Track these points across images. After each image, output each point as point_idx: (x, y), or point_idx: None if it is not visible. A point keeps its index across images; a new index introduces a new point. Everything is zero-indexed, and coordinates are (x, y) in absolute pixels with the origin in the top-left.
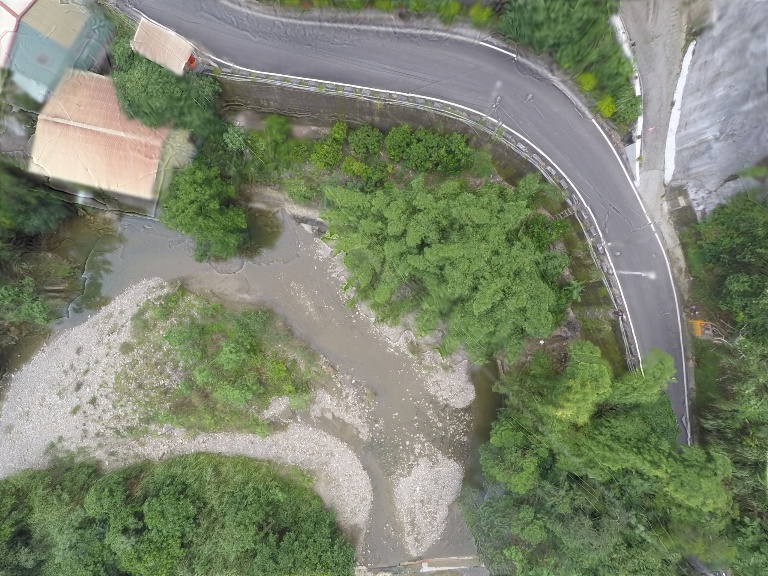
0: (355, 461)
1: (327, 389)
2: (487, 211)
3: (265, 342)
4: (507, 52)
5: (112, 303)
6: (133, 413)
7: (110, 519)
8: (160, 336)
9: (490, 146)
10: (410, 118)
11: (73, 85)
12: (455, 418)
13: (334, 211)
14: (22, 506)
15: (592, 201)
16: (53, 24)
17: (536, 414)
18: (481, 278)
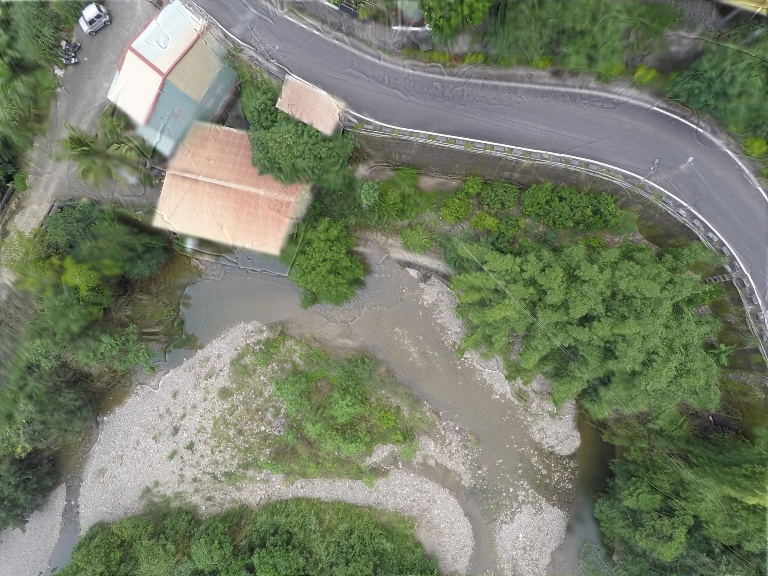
0: (457, 507)
1: (430, 436)
2: (657, 284)
3: (368, 388)
4: (667, 113)
5: (209, 346)
6: (232, 459)
7: (221, 572)
8: (261, 382)
9: (640, 207)
10: (555, 176)
11: (207, 141)
12: (560, 465)
13: (474, 271)
14: (129, 557)
15: (752, 268)
16: (205, 85)
17: (673, 477)
18: (655, 355)
